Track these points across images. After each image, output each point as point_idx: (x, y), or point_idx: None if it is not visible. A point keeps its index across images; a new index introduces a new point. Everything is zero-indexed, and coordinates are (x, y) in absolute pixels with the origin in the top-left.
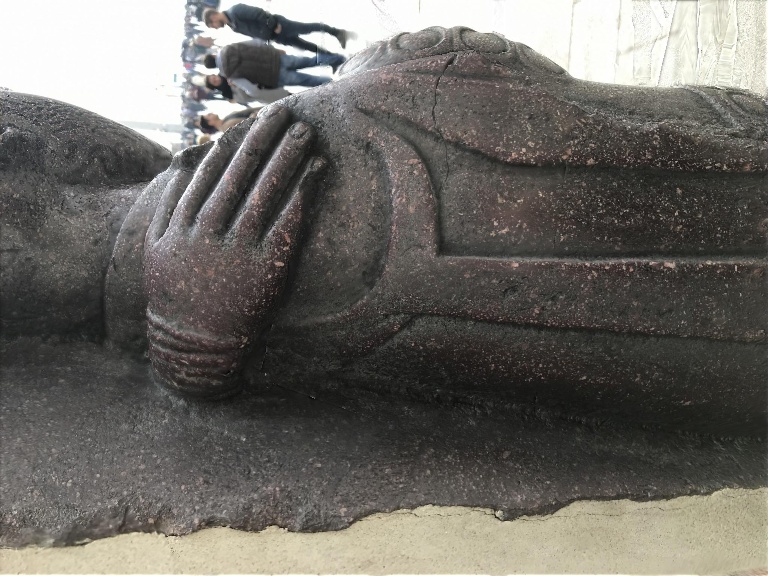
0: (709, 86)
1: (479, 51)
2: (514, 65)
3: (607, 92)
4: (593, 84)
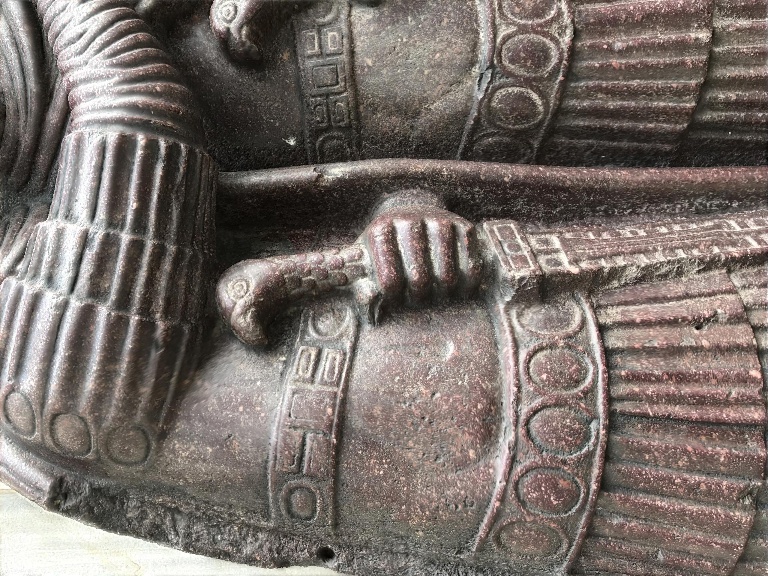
0: (290, 468)
1: (65, 452)
2: (95, 466)
3: (177, 480)
4: (168, 471)
